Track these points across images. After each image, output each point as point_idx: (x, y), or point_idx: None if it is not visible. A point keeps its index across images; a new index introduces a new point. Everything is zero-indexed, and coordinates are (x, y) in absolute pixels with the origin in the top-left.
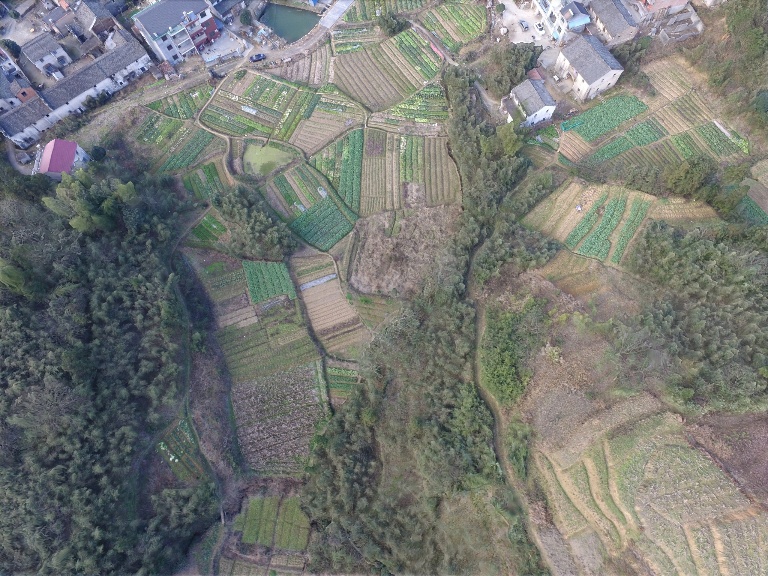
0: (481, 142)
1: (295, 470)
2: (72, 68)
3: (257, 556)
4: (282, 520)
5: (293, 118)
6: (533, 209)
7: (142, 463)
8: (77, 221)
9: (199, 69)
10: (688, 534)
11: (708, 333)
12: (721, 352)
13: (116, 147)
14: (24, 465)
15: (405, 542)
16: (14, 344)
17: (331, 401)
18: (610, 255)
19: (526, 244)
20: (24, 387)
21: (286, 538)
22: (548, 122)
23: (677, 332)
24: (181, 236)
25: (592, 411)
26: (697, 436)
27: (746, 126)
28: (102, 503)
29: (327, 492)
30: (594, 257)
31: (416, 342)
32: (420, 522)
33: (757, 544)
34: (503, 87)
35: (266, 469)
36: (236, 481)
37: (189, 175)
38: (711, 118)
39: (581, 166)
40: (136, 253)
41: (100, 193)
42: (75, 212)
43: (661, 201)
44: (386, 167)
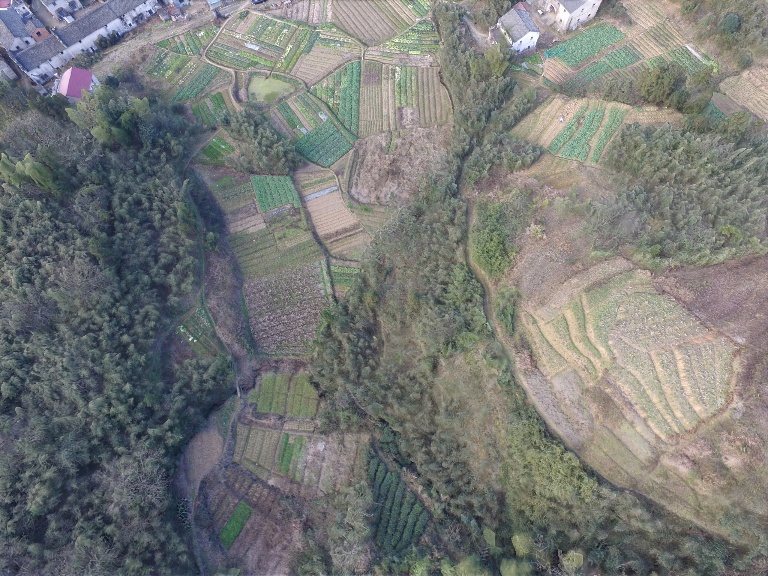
0: (470, 63)
1: (304, 352)
2: (82, 13)
3: (271, 421)
4: (293, 393)
5: (294, 53)
6: (519, 123)
7: (164, 343)
8: (98, 130)
9: (204, 11)
10: (654, 359)
11: (675, 208)
12: (686, 219)
13: (128, 81)
14: (59, 332)
15: (405, 400)
16: (45, 233)
17: (335, 294)
18: (589, 156)
19: (513, 150)
20: (56, 268)
21: (297, 407)
22: (533, 50)
23: (648, 208)
24: (192, 155)
25: (571, 273)
26: (664, 285)
27: (715, 49)
28: (131, 366)
29: (334, 364)
30: (575, 159)
31: (413, 233)
32: (419, 382)
33: (713, 360)
34: (490, 19)
35: (277, 352)
36: (250, 361)
37: (197, 104)
38: (683, 43)
39: (564, 87)
40: (152, 165)
41: (118, 106)
42: (96, 122)
43: (636, 109)
44: (382, 94)
